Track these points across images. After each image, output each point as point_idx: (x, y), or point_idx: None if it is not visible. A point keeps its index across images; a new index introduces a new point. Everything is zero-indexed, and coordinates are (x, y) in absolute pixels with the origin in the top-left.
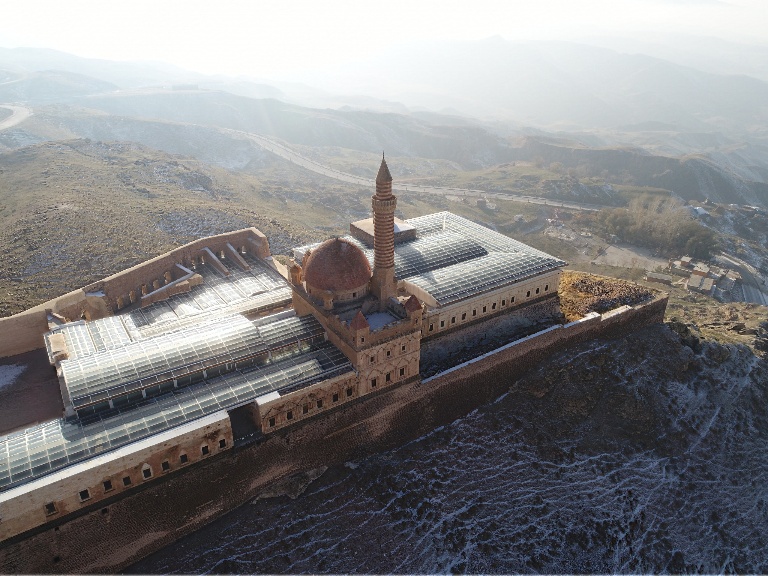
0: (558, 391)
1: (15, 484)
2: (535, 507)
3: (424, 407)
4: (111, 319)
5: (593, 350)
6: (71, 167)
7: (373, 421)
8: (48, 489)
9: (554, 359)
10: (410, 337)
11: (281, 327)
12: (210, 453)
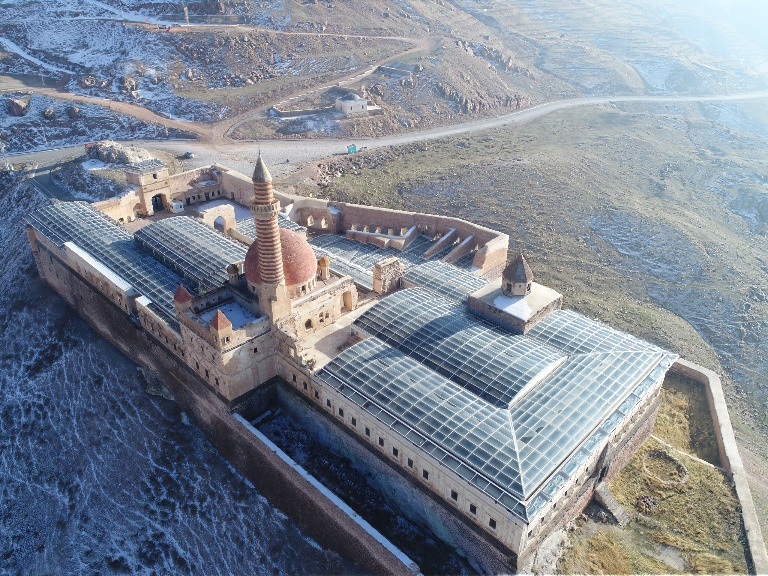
0: None
1: None
2: None
3: None
4: (293, 225)
5: None
6: (633, 140)
7: (199, 401)
8: None
9: None
10: (215, 351)
11: None
12: None
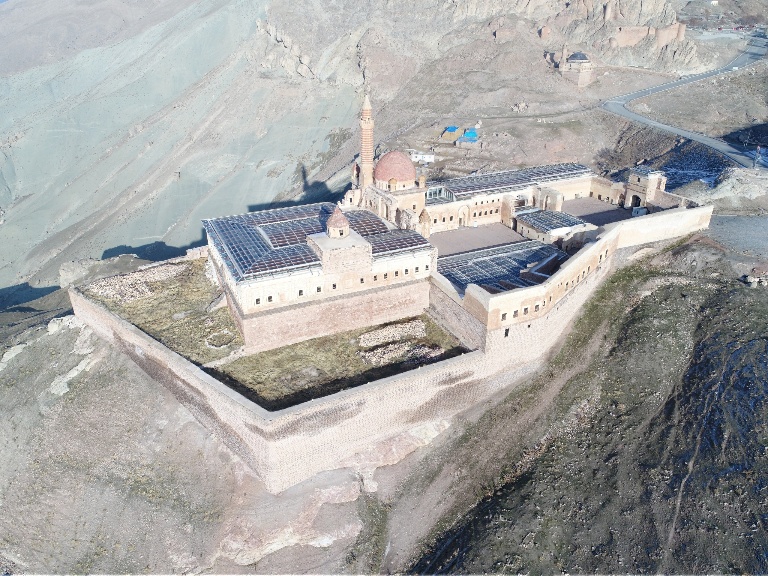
0: None
1: None
2: None
3: None
4: (555, 227)
5: None
6: None
7: None
8: None
9: None
10: None
11: None
12: None
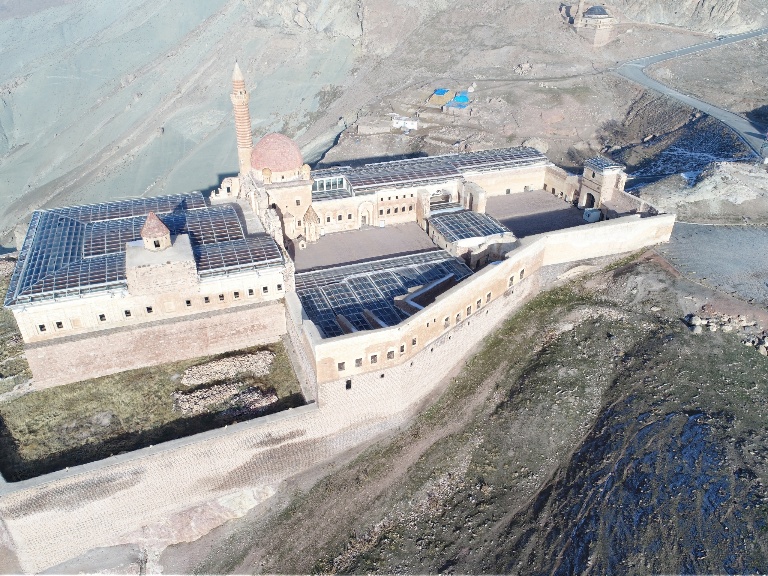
0: None
1: None
2: None
3: None
4: (464, 236)
5: None
6: None
7: None
8: None
9: None
10: None
11: None
12: None
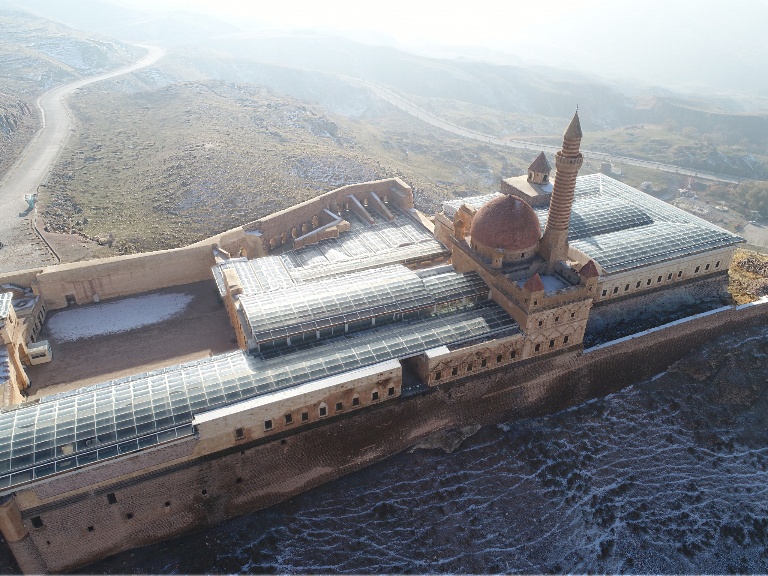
0: (721, 376)
1: (212, 407)
2: (689, 494)
3: (581, 377)
4: (271, 258)
5: (763, 336)
6: (210, 107)
7: (530, 386)
8: (240, 415)
9: (720, 342)
10: (581, 304)
11: (445, 282)
12: (379, 399)
